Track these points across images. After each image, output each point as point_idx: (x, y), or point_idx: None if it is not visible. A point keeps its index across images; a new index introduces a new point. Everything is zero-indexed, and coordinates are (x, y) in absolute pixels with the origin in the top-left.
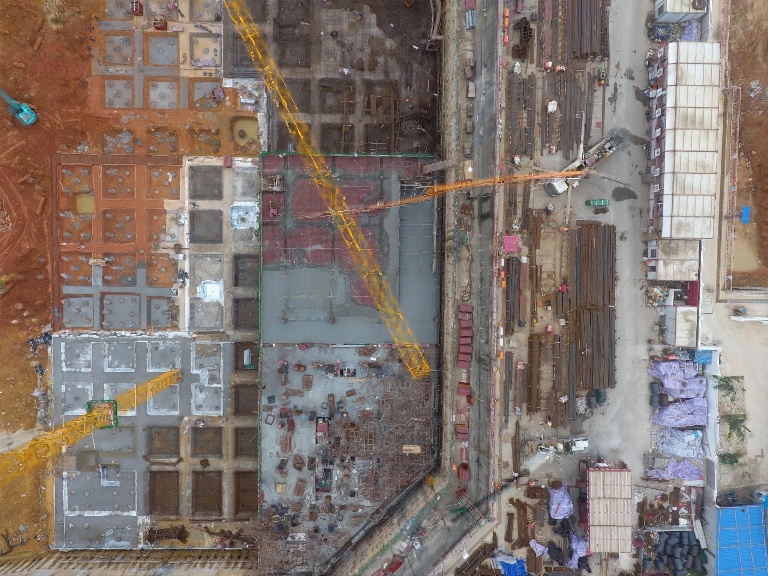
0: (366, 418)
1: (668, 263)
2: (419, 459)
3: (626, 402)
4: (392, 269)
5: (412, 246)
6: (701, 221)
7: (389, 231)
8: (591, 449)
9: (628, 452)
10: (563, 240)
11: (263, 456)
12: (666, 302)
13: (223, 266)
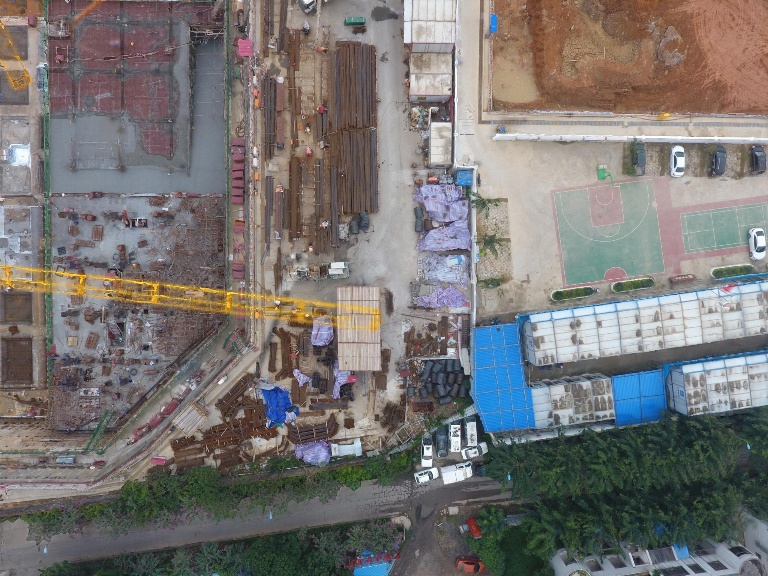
0: (158, 269)
1: (420, 77)
2: (209, 309)
3: (391, 229)
4: (183, 117)
5: (207, 97)
6: (442, 25)
7: (179, 78)
8: (356, 277)
9: (394, 280)
10: (322, 61)
11: (54, 309)
12: (428, 124)
13: (30, 128)
